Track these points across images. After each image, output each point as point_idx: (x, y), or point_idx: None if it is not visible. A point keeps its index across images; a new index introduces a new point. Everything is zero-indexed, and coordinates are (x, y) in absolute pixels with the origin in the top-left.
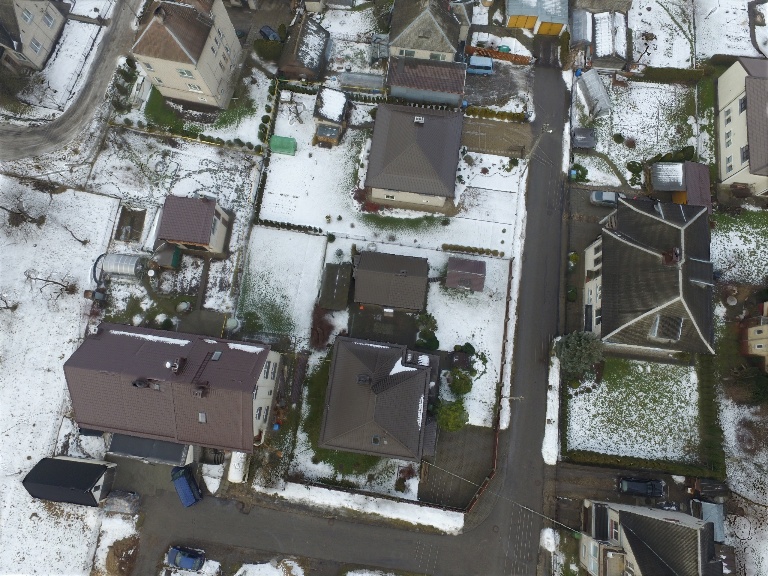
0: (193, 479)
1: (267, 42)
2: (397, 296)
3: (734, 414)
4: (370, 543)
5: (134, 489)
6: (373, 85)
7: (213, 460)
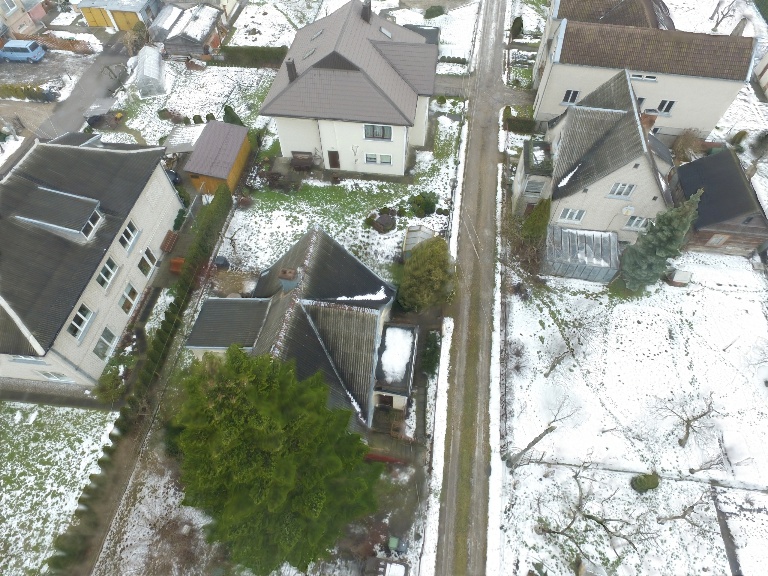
0: None
1: None
2: None
3: (162, 508)
4: None
5: None
6: None
7: None
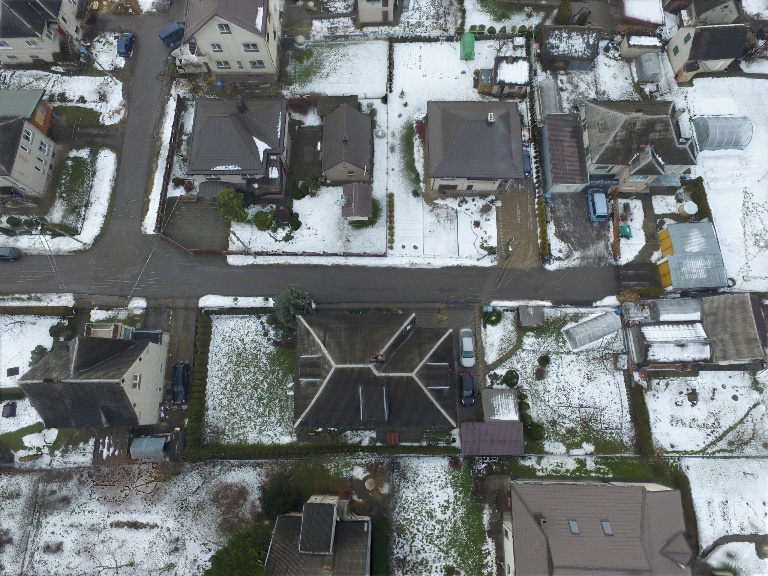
0: (180, 38)
1: (568, 9)
2: (330, 146)
3: (252, 482)
4: (136, 166)
5: (173, 5)
6: (546, 108)
7: (193, 46)
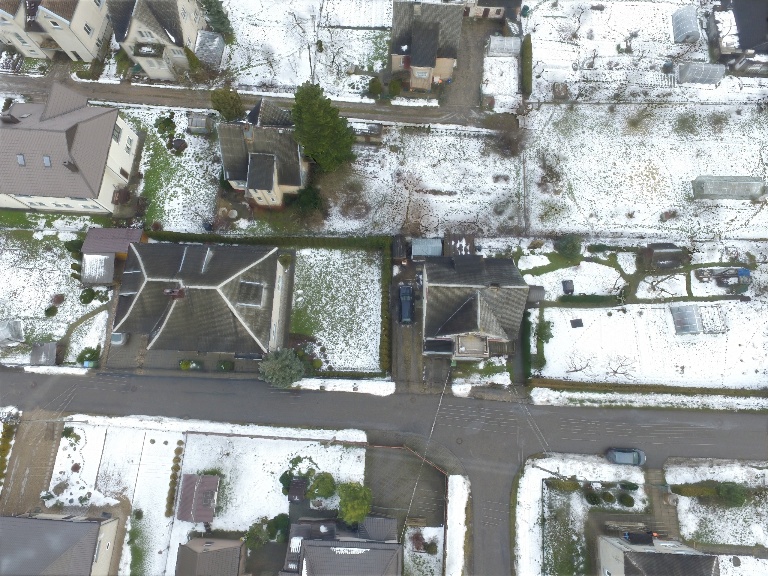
0: None
1: None
2: None
3: (337, 220)
4: None
5: None
6: None
7: None
